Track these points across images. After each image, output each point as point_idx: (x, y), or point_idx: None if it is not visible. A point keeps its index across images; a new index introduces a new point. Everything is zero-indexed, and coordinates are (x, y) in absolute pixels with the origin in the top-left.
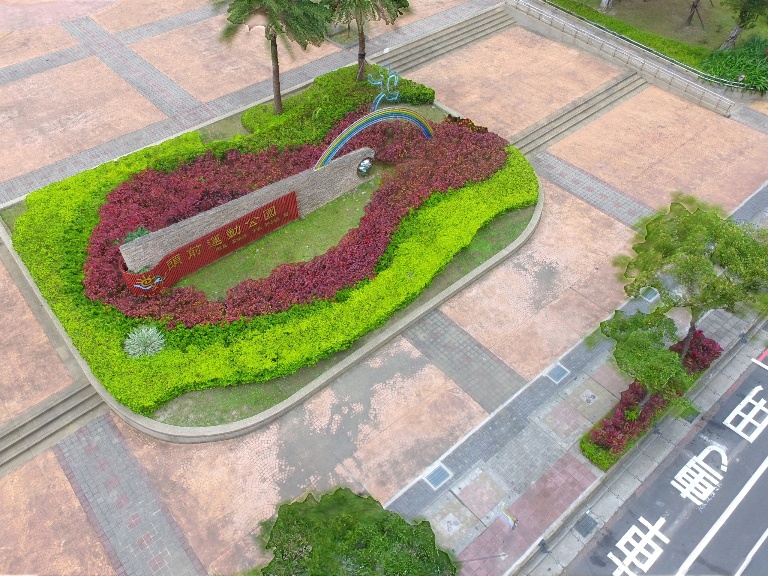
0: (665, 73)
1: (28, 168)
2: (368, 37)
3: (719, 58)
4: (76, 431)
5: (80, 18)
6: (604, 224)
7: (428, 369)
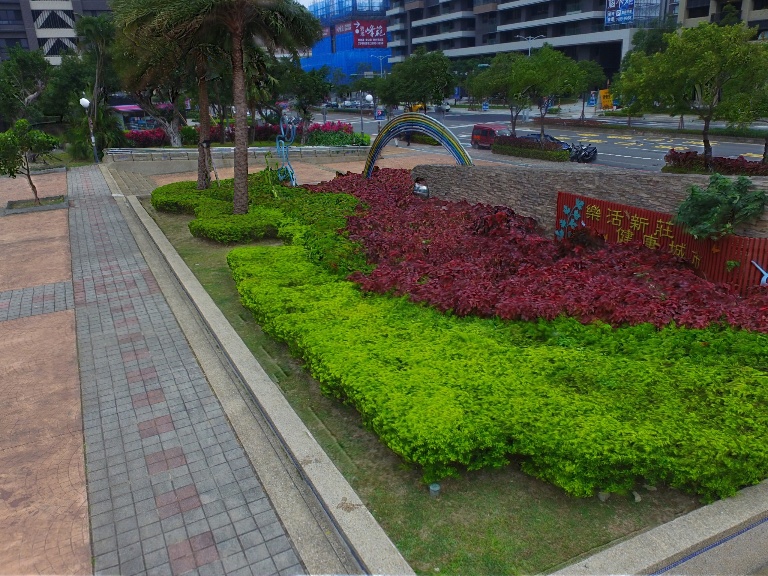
0: (321, 150)
1: (42, 573)
2: None
3: None
4: None
5: None
6: None
7: None
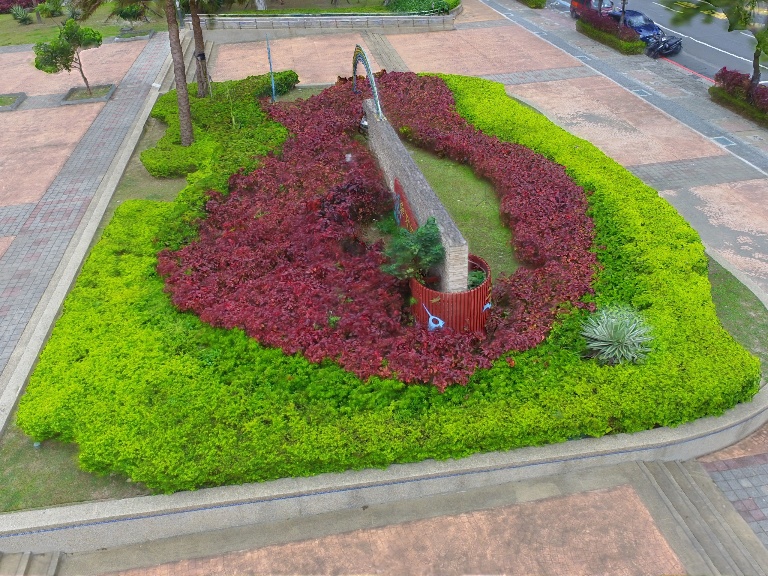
0: (389, 20)
1: None
2: None
3: (401, 3)
4: (745, 520)
5: None
6: (543, 86)
7: (697, 191)
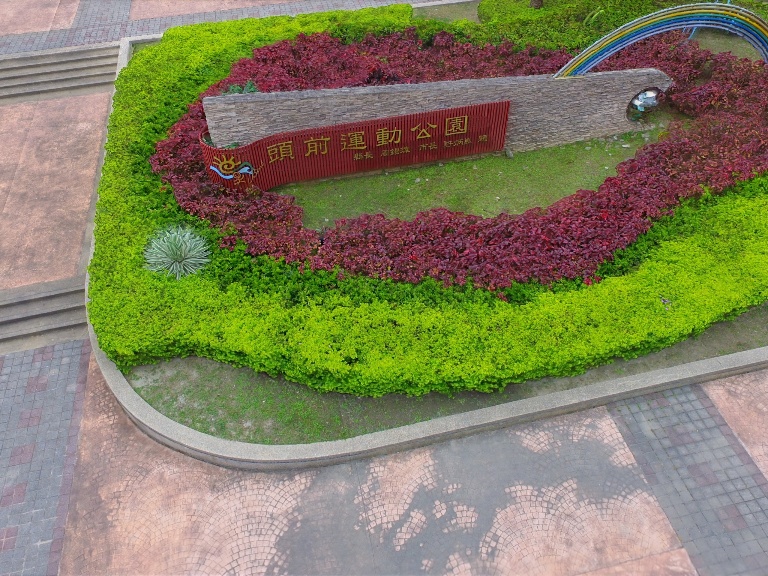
0: None
1: (199, 8)
2: None
3: None
4: (37, 348)
5: None
6: None
7: (639, 501)
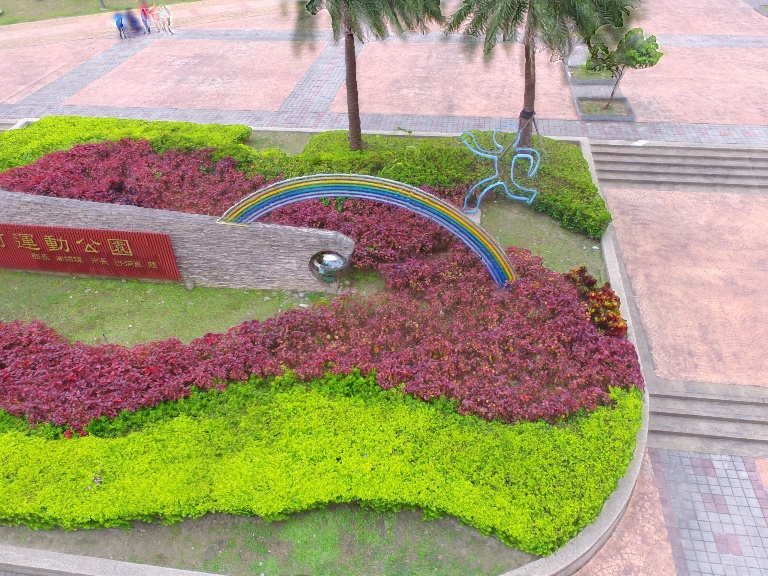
0: None
1: (116, 103)
2: (637, 117)
3: None
4: None
5: None
6: None
7: None
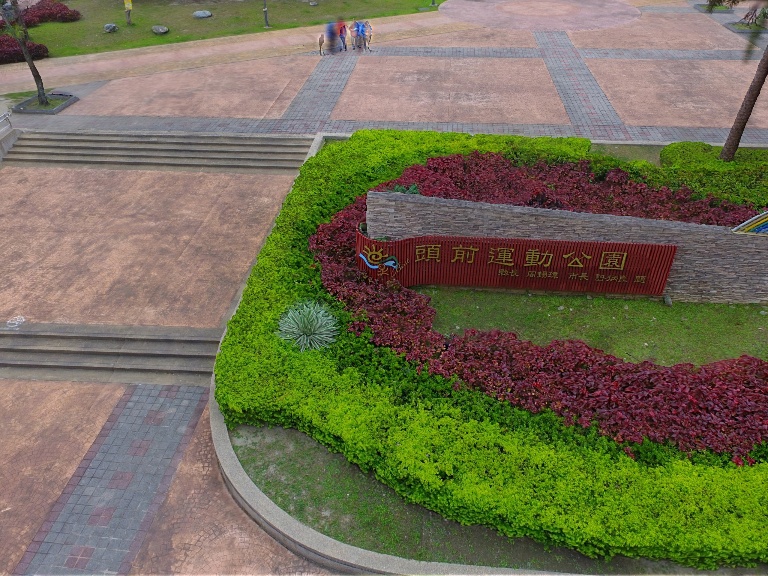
0: None
1: (390, 118)
2: None
3: None
4: (166, 385)
5: (556, 31)
6: None
7: None
